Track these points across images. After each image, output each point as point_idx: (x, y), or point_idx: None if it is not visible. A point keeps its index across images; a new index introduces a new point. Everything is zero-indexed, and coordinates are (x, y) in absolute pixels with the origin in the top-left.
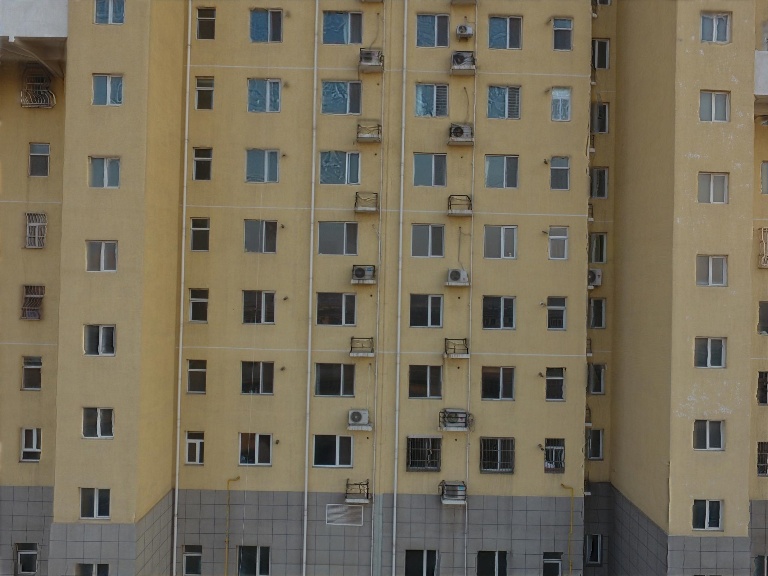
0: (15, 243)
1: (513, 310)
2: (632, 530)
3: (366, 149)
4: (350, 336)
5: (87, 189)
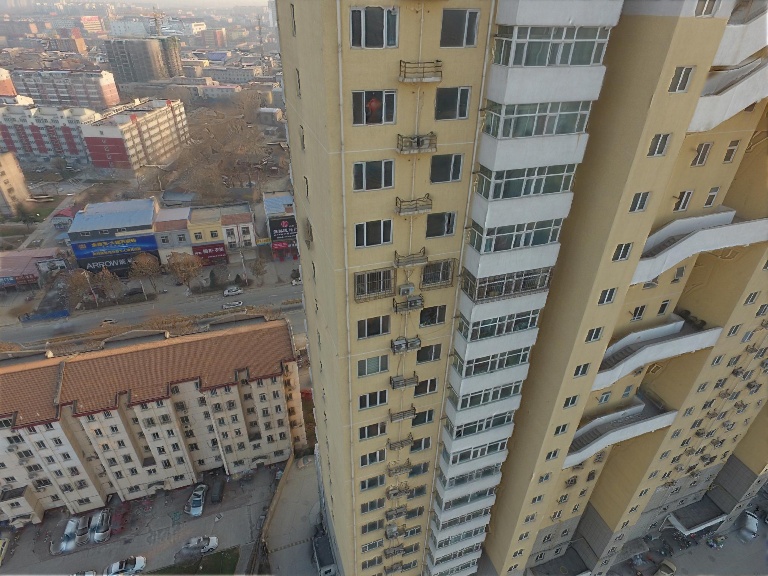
0: (591, 462)
1: (734, 424)
2: (737, 466)
3: (719, 397)
4: (686, 448)
5: (657, 461)
